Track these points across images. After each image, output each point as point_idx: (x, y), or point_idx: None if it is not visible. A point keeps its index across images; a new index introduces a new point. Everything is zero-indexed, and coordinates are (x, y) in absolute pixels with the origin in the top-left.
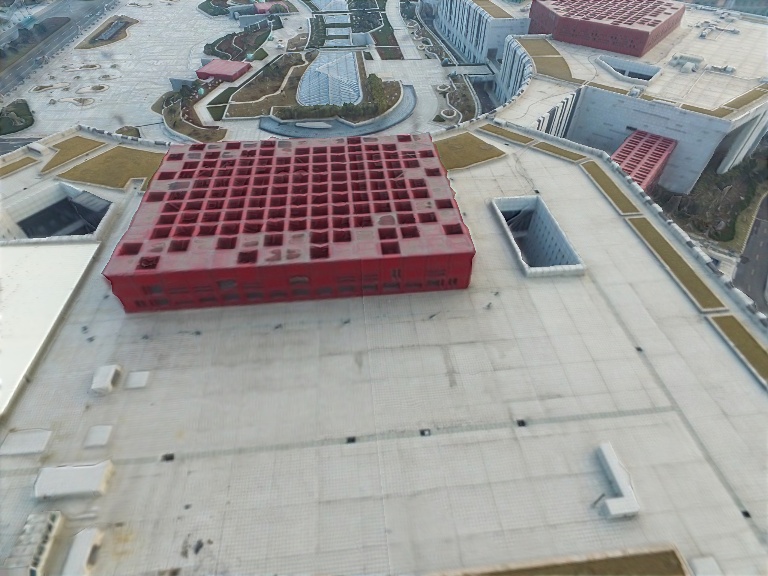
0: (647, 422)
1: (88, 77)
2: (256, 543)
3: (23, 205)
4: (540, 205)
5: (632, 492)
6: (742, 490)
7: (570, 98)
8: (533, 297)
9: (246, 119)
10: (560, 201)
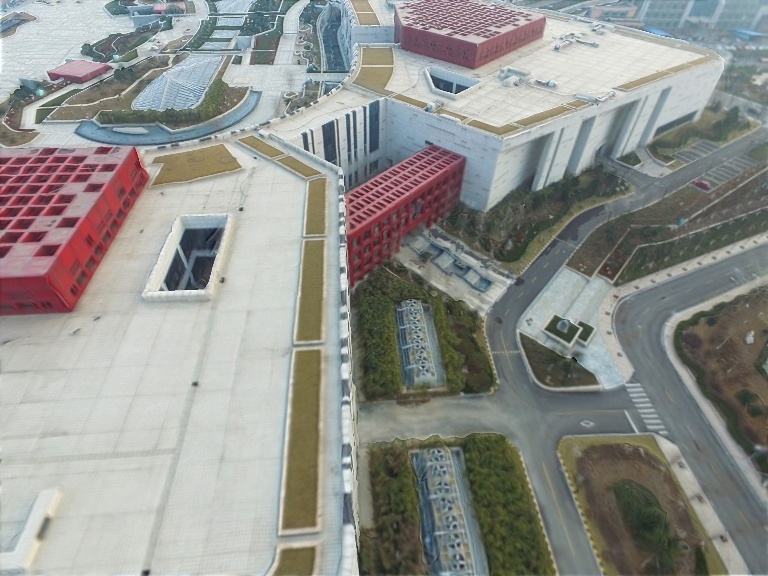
0: (131, 466)
1: None
2: None
3: None
4: None
5: (34, 546)
6: (165, 546)
7: (359, 110)
8: (132, 324)
9: (67, 122)
10: (255, 220)
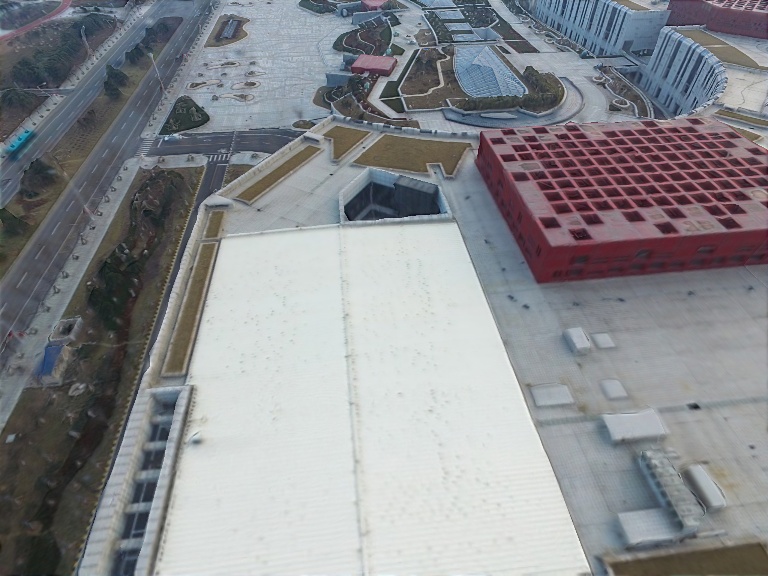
0: None
1: (234, 74)
2: None
3: (351, 189)
4: None
5: None
6: None
7: None
8: None
9: (428, 111)
10: None
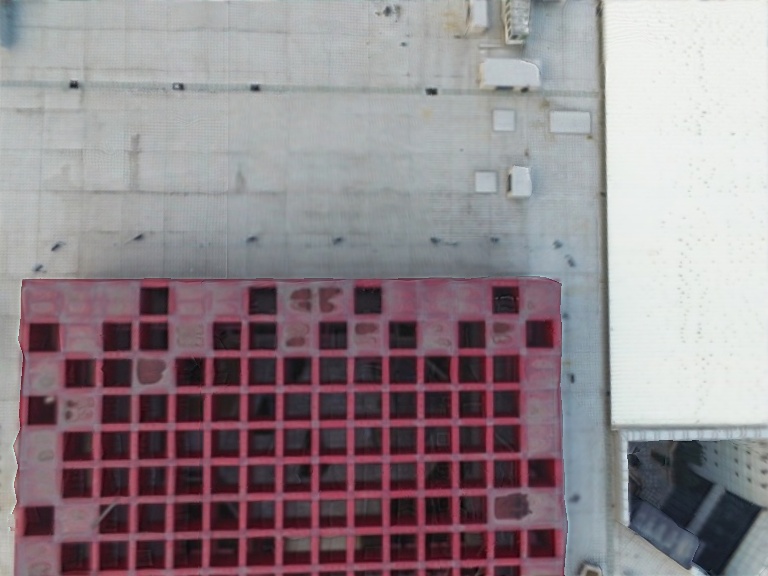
0: None
1: None
2: (339, 7)
3: None
4: None
5: None
6: None
7: None
8: None
9: None
10: None
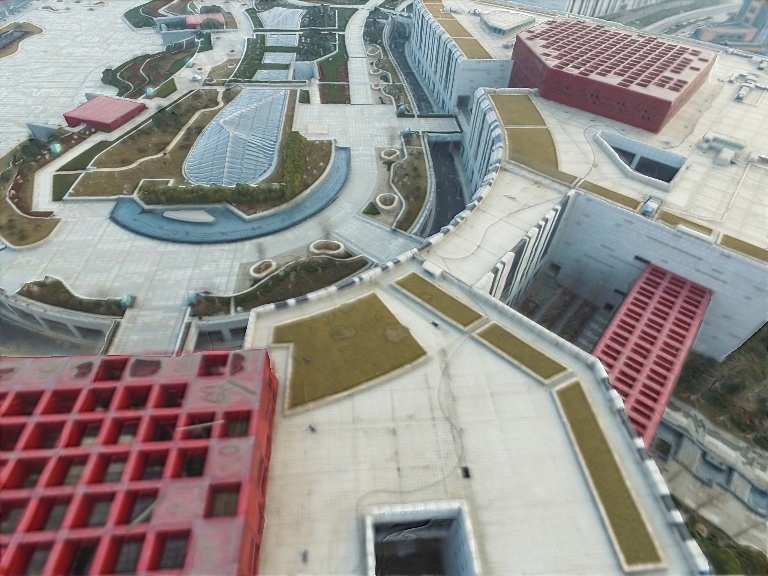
0: None
1: None
2: None
3: None
4: (463, 527)
5: None
6: None
7: (551, 217)
8: None
9: (98, 200)
10: (506, 508)
